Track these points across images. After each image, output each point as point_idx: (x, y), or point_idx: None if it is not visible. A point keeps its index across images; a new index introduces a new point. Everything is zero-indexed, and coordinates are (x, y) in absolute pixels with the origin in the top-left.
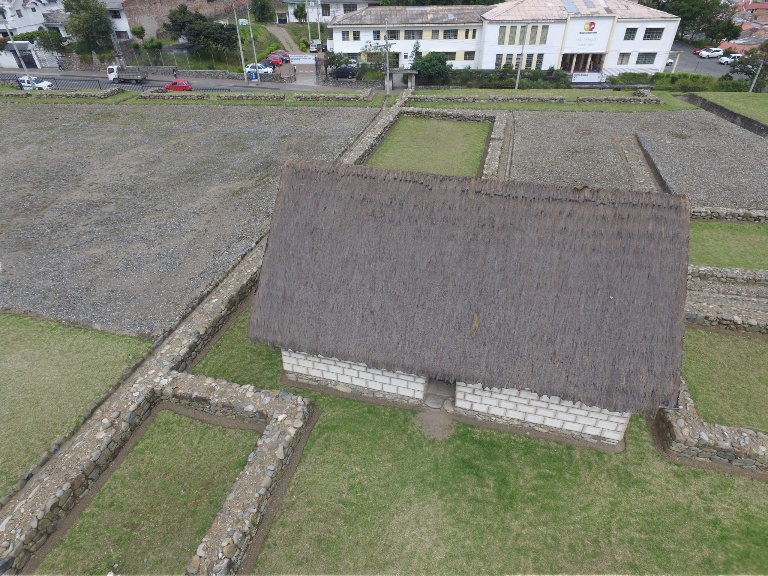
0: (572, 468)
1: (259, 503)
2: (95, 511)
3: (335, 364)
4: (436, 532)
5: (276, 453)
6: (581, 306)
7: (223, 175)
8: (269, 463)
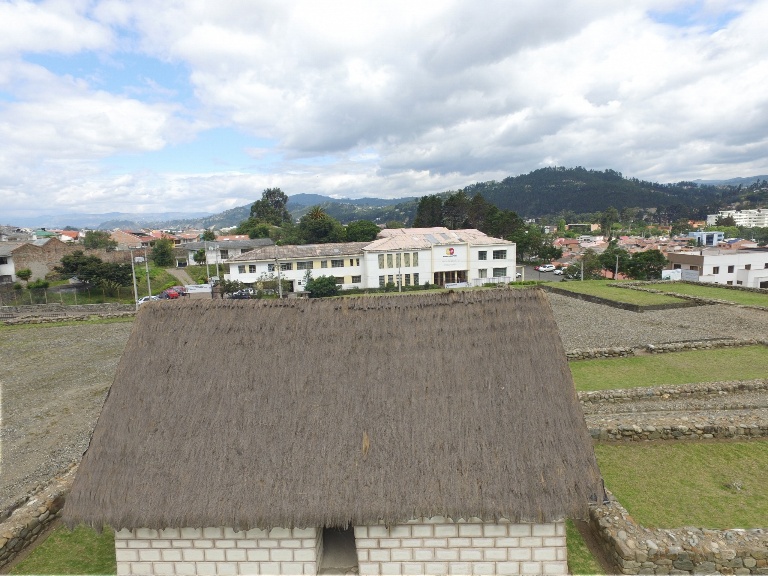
0: None
1: None
2: None
3: (192, 545)
4: None
5: None
6: (475, 402)
7: (87, 379)
8: None
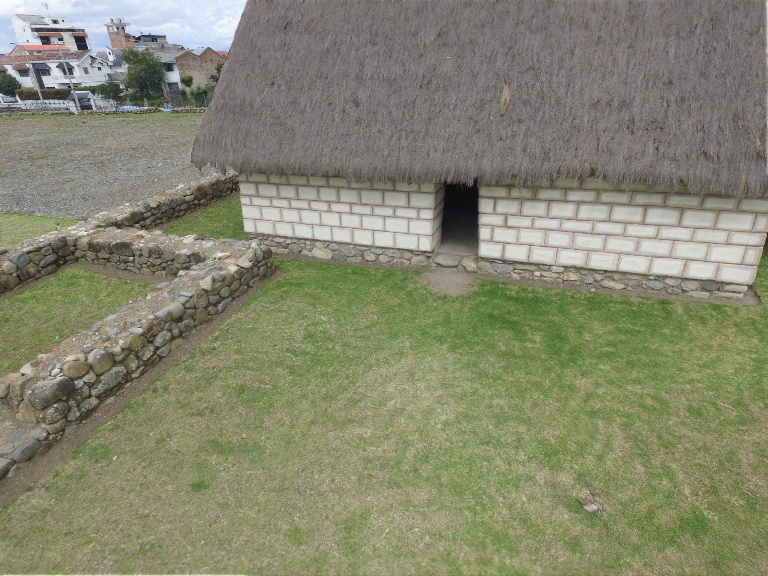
0: (673, 323)
1: (151, 325)
2: None
3: (309, 207)
4: (441, 387)
5: (200, 282)
6: (670, 51)
7: None
8: (185, 290)
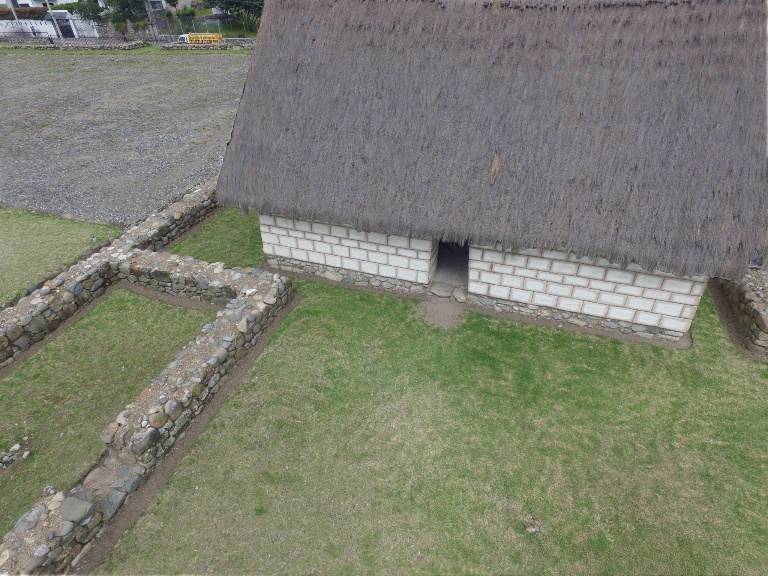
0: (619, 364)
1: (206, 373)
2: (15, 380)
3: (322, 239)
4: (432, 424)
5: (237, 325)
6: (640, 137)
7: (233, 102)
8: (226, 334)
